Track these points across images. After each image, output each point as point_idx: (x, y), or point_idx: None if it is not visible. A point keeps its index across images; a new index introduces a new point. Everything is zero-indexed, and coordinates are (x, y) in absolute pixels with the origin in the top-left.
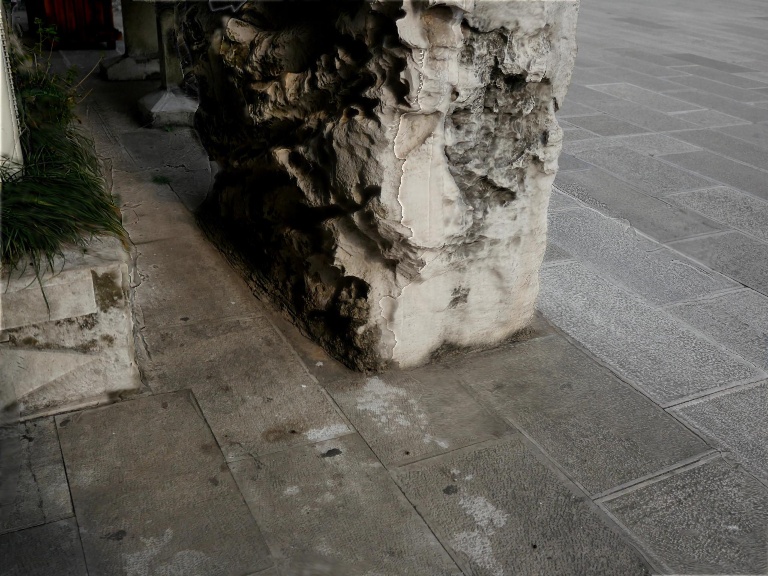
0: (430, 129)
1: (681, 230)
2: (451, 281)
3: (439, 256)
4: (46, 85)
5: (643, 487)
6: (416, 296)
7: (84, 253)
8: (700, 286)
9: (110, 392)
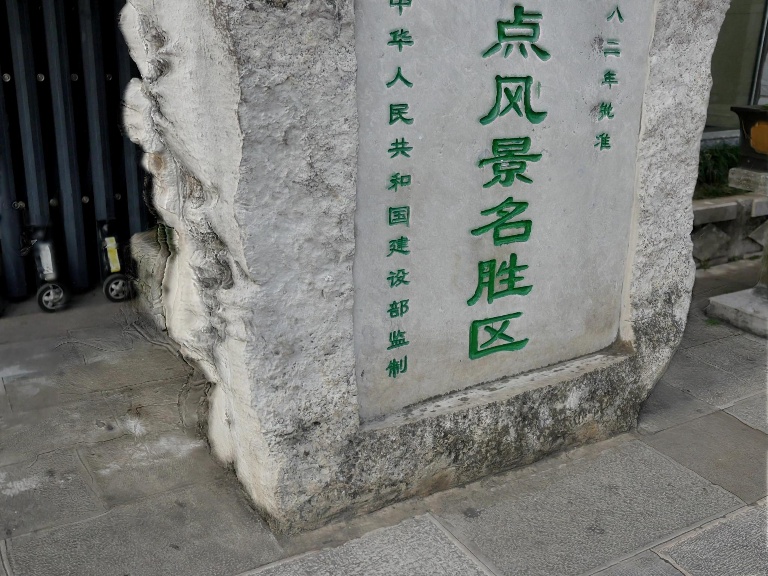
0: None
1: None
2: None
3: None
4: None
5: (0, 575)
6: None
7: None
8: None
9: None
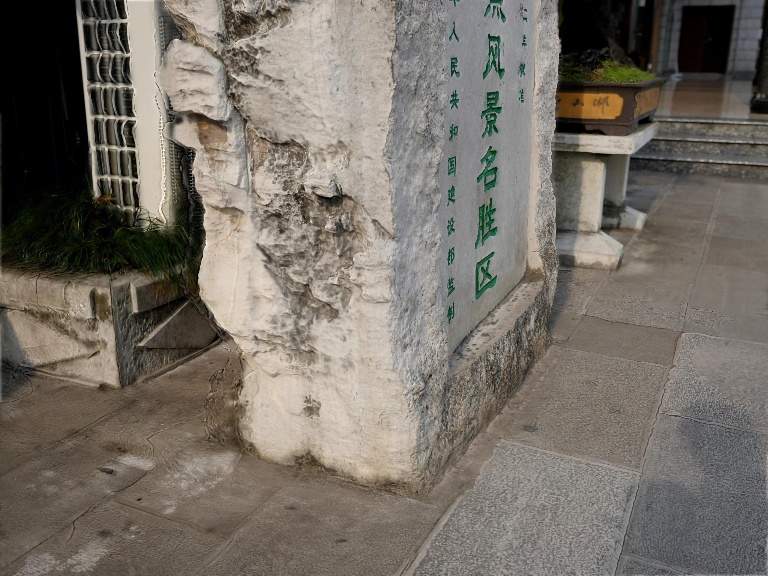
0: (238, 224)
1: None
2: (303, 387)
3: (276, 353)
4: None
5: None
6: (273, 389)
7: (88, 273)
8: None
9: (97, 380)
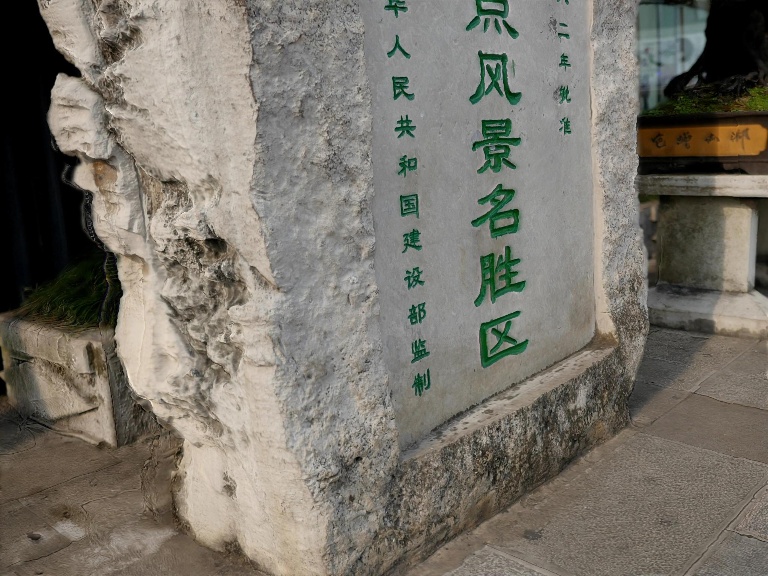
0: None
1: None
2: (222, 461)
3: (192, 420)
4: None
5: None
6: (201, 461)
7: None
8: None
9: (99, 437)
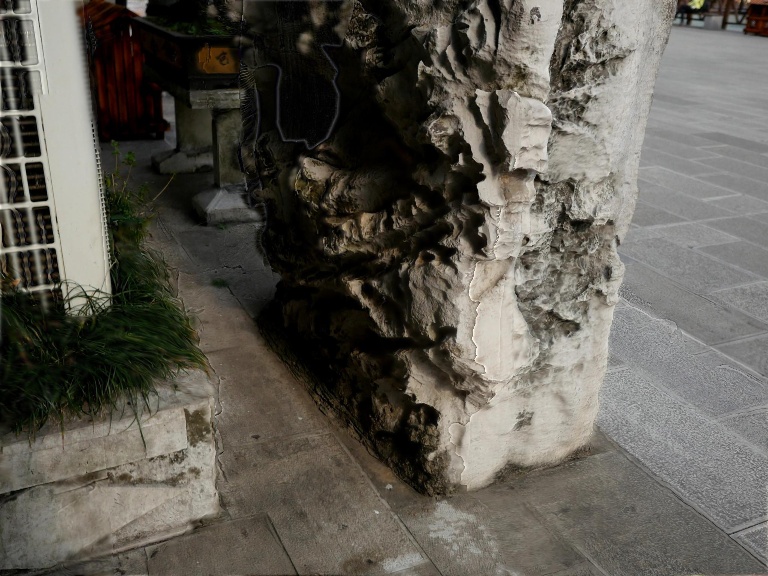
0: (502, 272)
1: (727, 331)
2: (516, 405)
3: (506, 384)
4: (121, 203)
5: None
6: (483, 421)
7: (175, 389)
8: (752, 394)
9: None
